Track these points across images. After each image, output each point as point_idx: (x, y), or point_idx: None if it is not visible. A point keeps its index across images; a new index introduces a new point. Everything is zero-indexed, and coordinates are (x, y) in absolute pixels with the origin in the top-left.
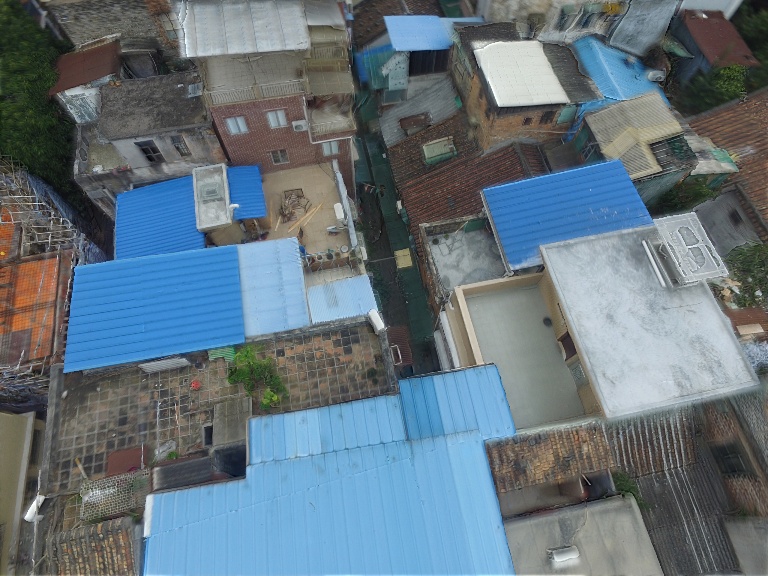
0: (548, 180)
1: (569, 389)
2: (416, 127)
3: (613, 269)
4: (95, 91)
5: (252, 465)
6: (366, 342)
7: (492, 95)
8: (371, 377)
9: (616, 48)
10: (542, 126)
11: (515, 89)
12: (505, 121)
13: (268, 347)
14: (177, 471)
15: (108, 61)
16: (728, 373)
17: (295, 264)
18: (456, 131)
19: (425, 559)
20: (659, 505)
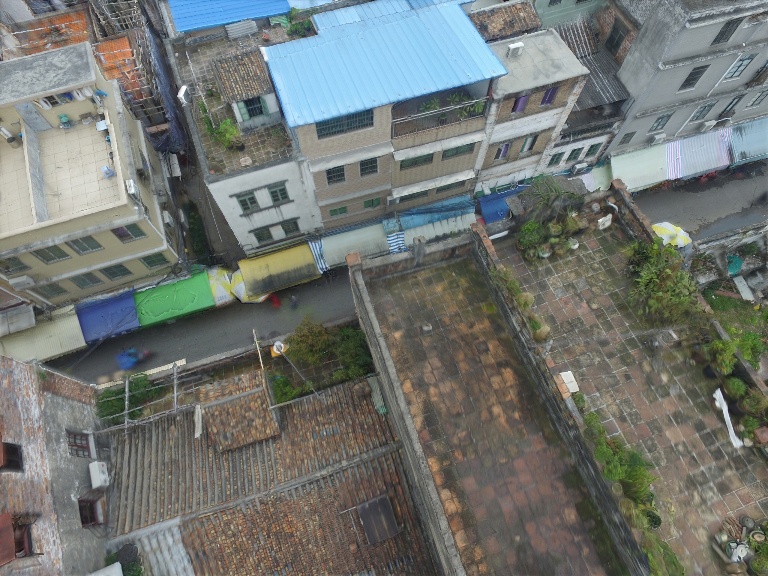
0: None
1: None
2: None
3: None
4: None
5: None
6: None
7: None
8: None
9: None
10: None
11: None
12: None
13: (308, 17)
14: None
15: None
16: None
17: None
18: None
19: (435, 47)
20: None
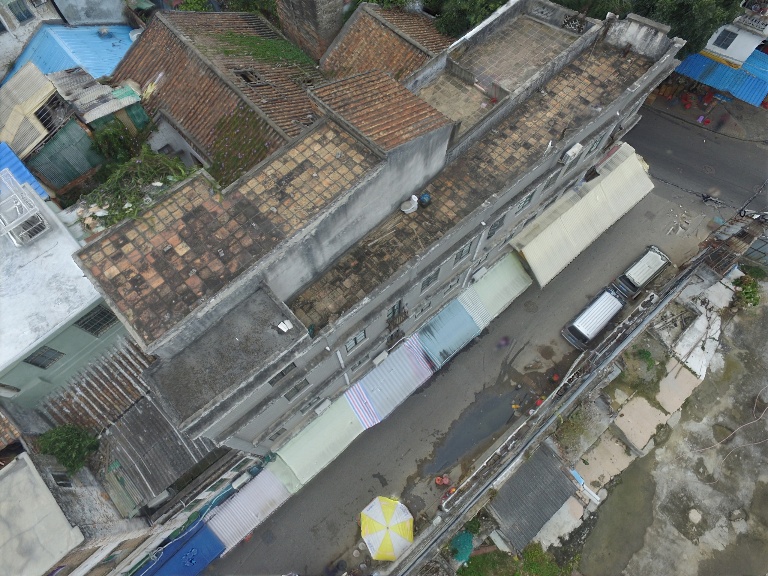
0: None
1: None
2: None
3: None
4: None
5: None
6: None
7: None
8: None
9: (82, 25)
10: None
11: None
12: None
13: None
14: None
15: None
16: (83, 295)
17: None
18: None
19: None
20: (147, 429)
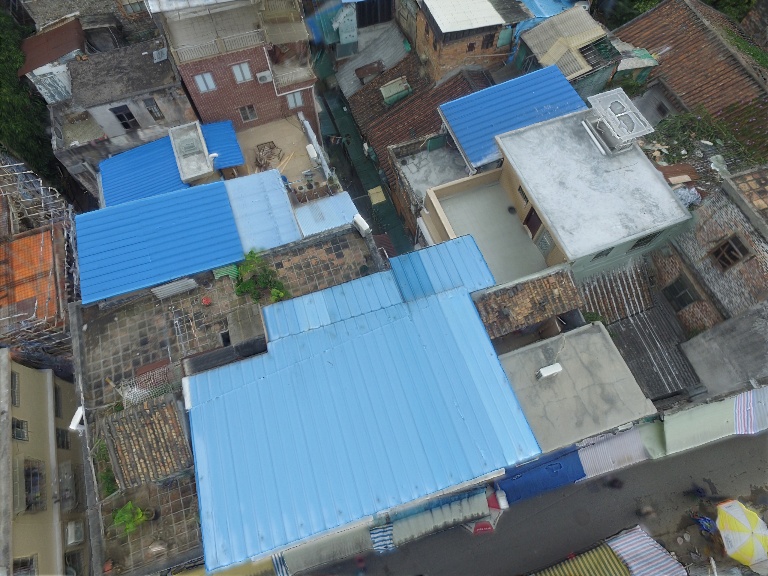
0: (495, 89)
1: (538, 262)
2: (371, 75)
3: (560, 147)
4: (62, 69)
5: (272, 341)
6: (355, 246)
7: (435, 24)
8: (364, 273)
9: None
10: (484, 51)
11: (455, 16)
12: (450, 49)
13: (267, 262)
14: (205, 360)
15: (71, 38)
16: (665, 213)
17: (280, 191)
18: (408, 71)
19: (433, 387)
20: (628, 345)
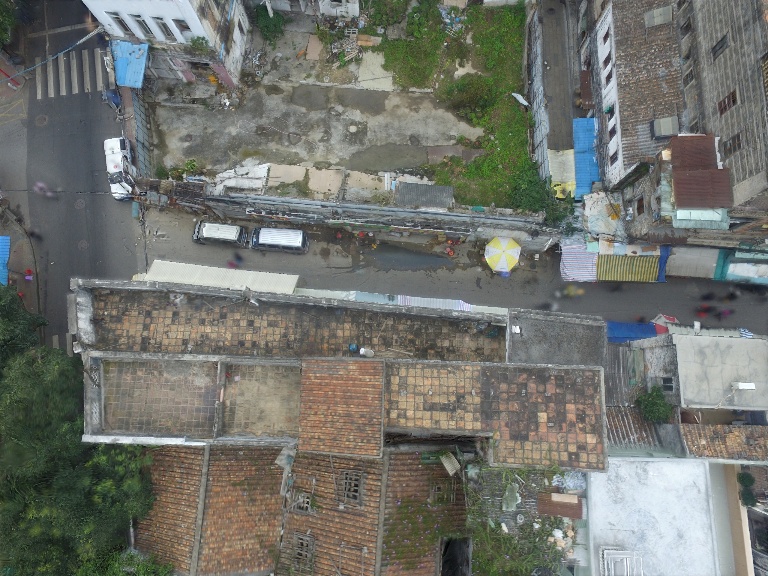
0: None
1: None
2: None
3: None
4: None
5: None
6: None
7: None
8: None
9: None
10: None
11: None
12: None
13: None
14: None
15: None
16: None
17: None
18: None
19: None
20: None
